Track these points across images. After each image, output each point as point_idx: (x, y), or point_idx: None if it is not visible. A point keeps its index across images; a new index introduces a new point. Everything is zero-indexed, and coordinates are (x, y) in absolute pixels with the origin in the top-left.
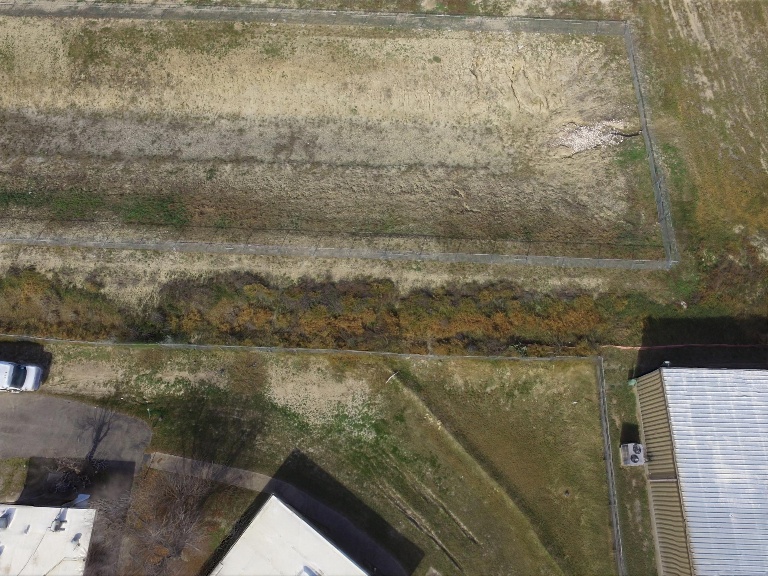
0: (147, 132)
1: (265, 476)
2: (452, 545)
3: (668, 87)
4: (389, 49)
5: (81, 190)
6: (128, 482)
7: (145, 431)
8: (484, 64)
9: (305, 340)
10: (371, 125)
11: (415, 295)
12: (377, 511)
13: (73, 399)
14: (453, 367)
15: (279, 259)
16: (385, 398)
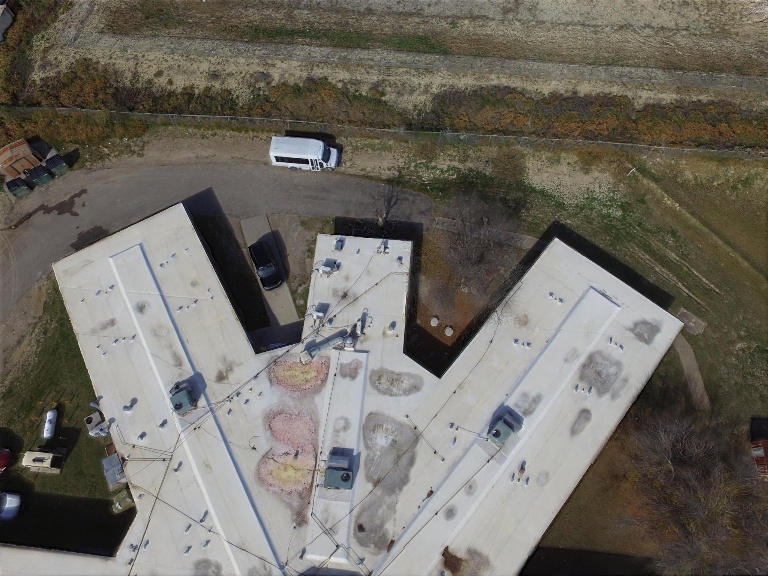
0: None
1: (533, 238)
2: (698, 293)
3: None
4: None
5: (349, 30)
6: (419, 237)
7: (428, 202)
8: None
9: None
10: None
11: (651, 107)
12: (631, 267)
13: (364, 178)
14: (684, 165)
15: (531, 78)
16: (627, 187)
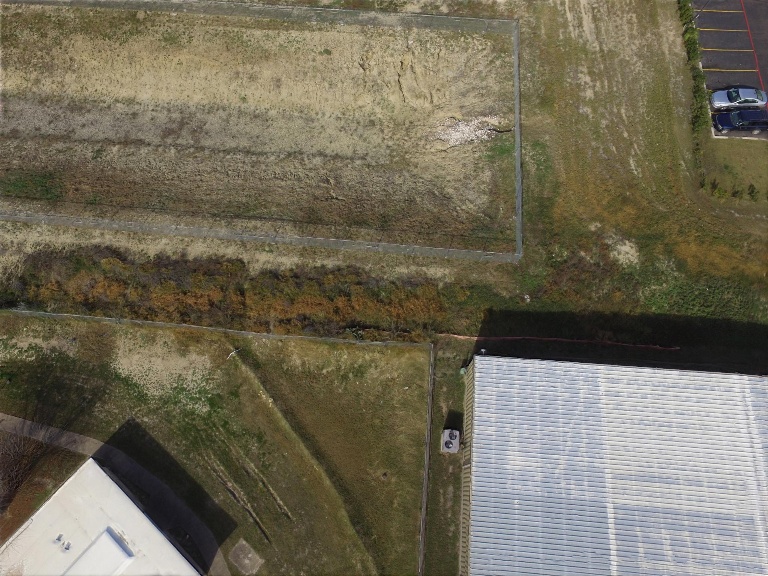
0: (46, 112)
1: (98, 441)
2: (265, 518)
3: (548, 85)
4: (282, 41)
5: None
6: None
7: None
8: (373, 58)
9: (153, 314)
10: (258, 113)
11: (262, 276)
12: (199, 481)
13: None
14: (293, 347)
15: (139, 236)
16: (224, 374)
